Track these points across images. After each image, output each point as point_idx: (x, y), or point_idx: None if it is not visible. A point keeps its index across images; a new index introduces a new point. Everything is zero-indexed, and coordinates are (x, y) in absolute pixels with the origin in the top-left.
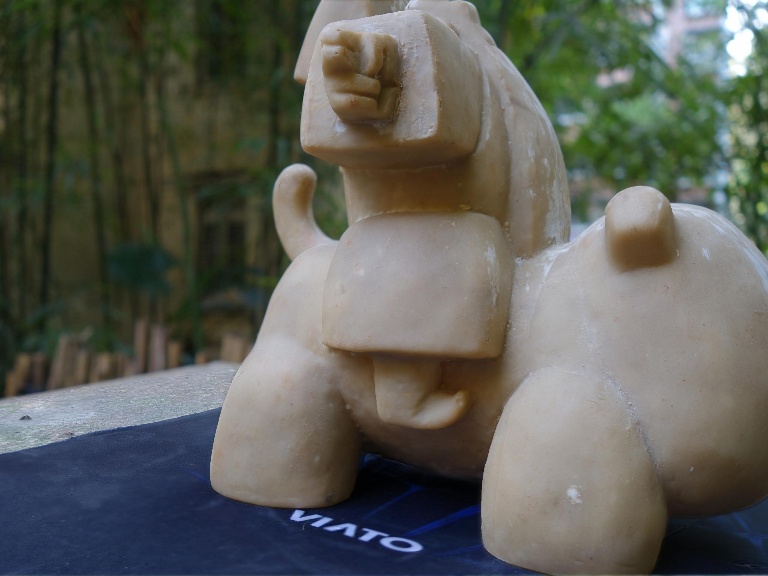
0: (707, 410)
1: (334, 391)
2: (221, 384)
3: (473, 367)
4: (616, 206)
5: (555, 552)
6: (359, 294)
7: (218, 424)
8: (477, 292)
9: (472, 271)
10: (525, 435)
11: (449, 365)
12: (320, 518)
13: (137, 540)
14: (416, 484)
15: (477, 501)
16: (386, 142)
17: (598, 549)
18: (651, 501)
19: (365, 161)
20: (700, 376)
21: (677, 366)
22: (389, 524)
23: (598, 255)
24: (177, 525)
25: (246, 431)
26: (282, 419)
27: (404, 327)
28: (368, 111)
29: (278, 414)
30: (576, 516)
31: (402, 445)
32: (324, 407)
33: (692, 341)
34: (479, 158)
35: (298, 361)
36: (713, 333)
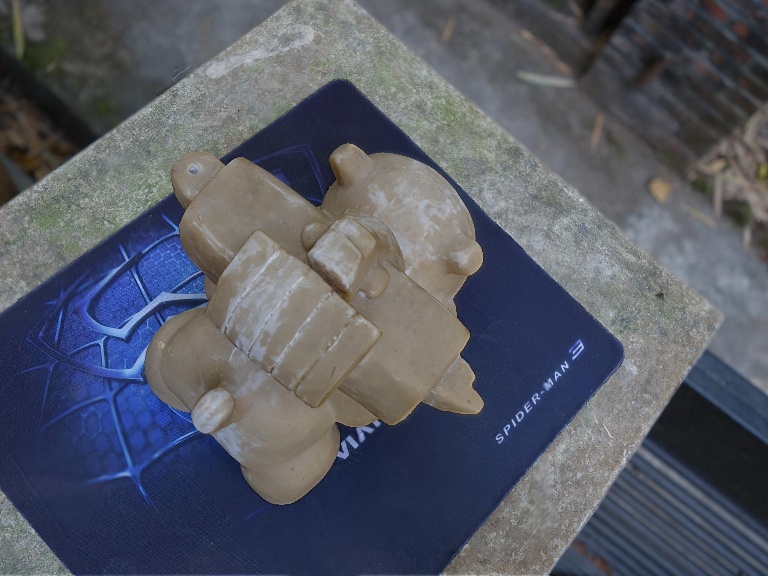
0: None
1: None
2: None
3: None
4: None
5: None
6: None
7: None
8: None
9: None
10: None
11: None
12: (347, 442)
13: (365, 542)
14: None
15: None
16: None
17: None
18: None
19: None
20: None
21: None
22: None
23: None
24: (347, 522)
25: None
26: None
27: None
28: None
29: None
30: None
31: None
32: None
33: None
34: None
35: None
36: None
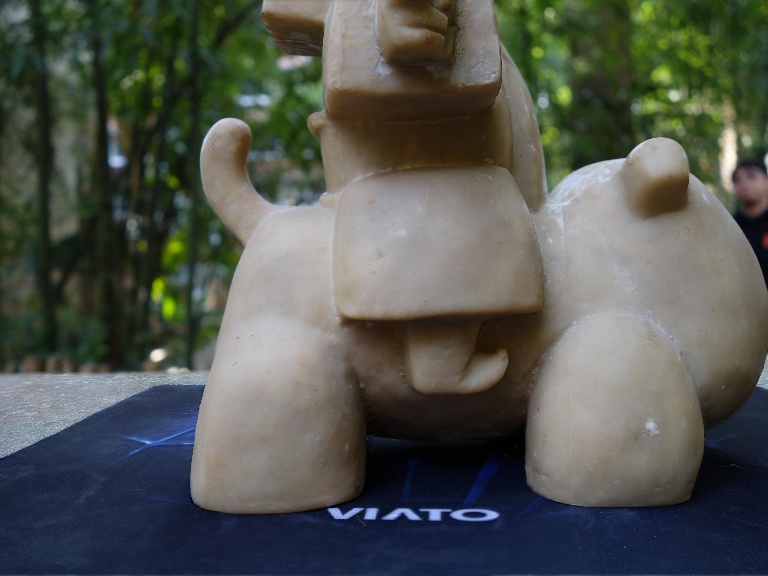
0: (733, 334)
1: (350, 369)
2: (36, 398)
3: (510, 323)
4: (647, 156)
5: (637, 484)
6: (404, 256)
7: (207, 429)
8: (528, 245)
9: (520, 224)
10: (594, 380)
11: (485, 324)
12: (364, 510)
13: None
14: (408, 458)
15: (482, 461)
16: (442, 87)
17: (675, 472)
18: (702, 421)
19: (389, 110)
20: (725, 305)
21: (706, 298)
22: (436, 499)
23: (615, 204)
24: (224, 556)
25: (260, 430)
26: (307, 408)
27: (464, 287)
28: (437, 50)
29: (301, 403)
30: (656, 446)
31: (414, 417)
32: (346, 388)
33: (715, 275)
34: (498, 110)
35: (309, 341)
36: (728, 267)
